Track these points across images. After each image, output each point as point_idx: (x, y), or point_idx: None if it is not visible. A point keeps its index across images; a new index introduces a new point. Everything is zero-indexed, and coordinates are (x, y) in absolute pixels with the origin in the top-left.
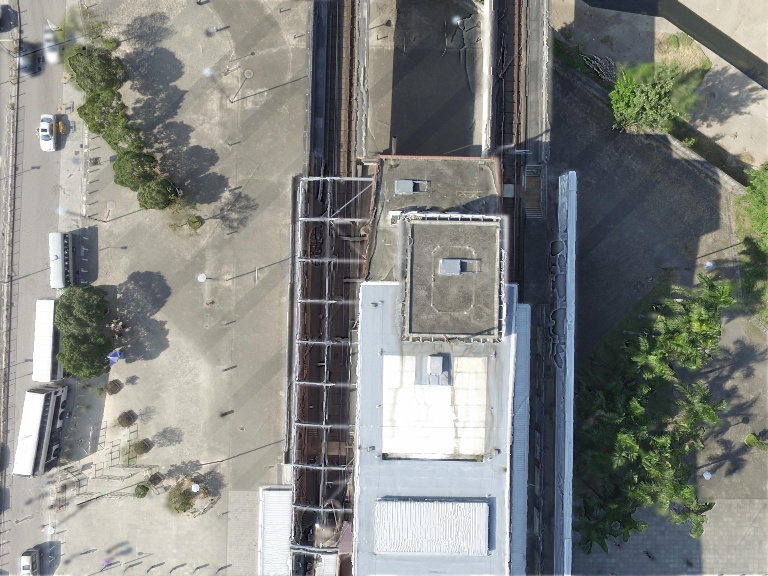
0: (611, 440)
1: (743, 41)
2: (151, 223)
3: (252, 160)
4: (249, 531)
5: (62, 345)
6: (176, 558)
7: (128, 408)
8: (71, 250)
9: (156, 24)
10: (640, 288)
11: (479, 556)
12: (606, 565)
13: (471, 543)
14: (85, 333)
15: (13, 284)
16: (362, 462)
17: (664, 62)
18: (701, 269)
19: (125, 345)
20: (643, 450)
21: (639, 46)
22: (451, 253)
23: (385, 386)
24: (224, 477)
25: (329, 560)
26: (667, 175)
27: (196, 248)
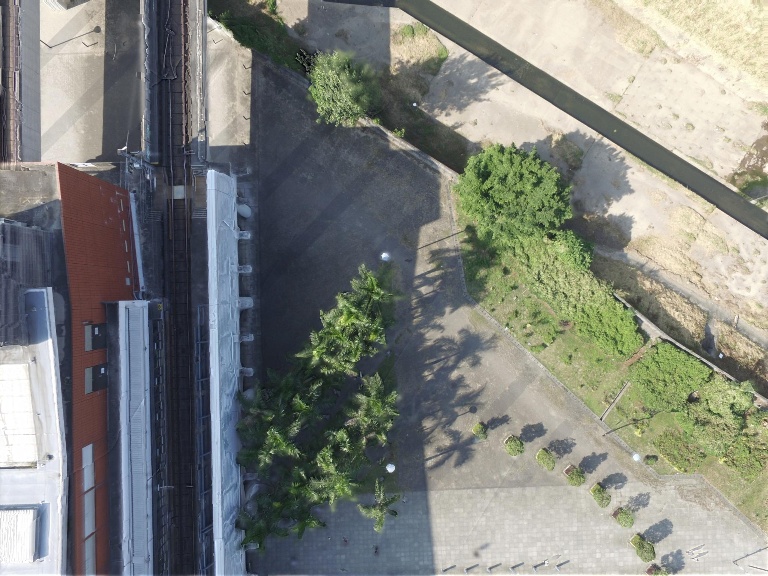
0: (264, 438)
1: (480, 27)
2: None
3: None
4: None
5: None
6: None
7: None
8: None
9: None
10: None
11: None
12: (336, 561)
13: (12, 550)
14: None
15: None
16: None
17: (400, 53)
18: (422, 260)
19: None
20: (321, 446)
21: (374, 38)
22: None
23: None
24: None
25: None
26: (384, 167)
27: None
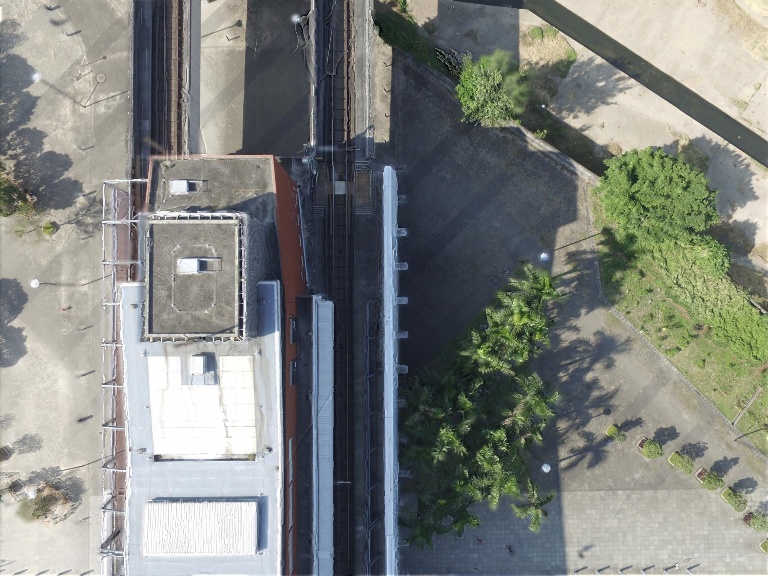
0: (434, 435)
1: (609, 31)
2: (6, 230)
3: (106, 164)
4: None
5: None
6: (39, 564)
7: None
8: None
9: (8, 31)
10: (497, 282)
11: (249, 555)
12: (469, 560)
13: (237, 543)
14: None
15: None
16: (133, 464)
17: (529, 54)
18: (559, 261)
19: None
20: (479, 444)
21: (503, 39)
22: (191, 252)
23: (152, 387)
24: (85, 482)
25: None
26: (523, 167)
27: (52, 254)
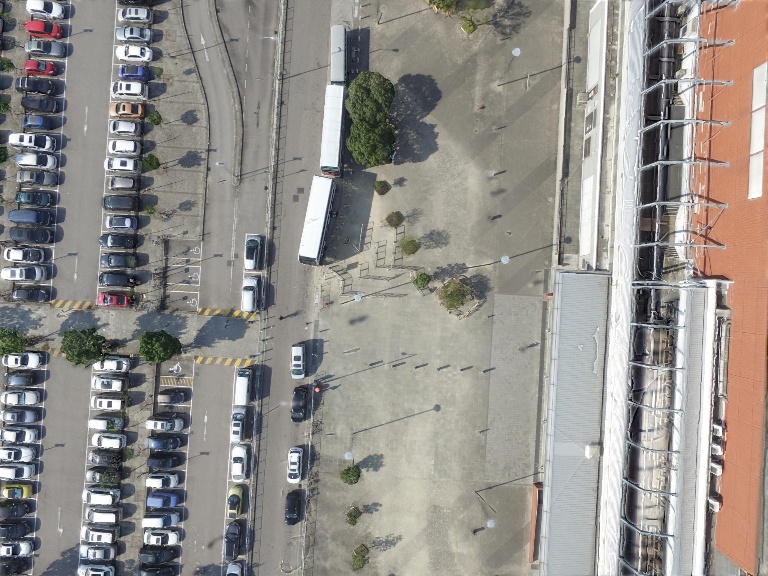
0: None
1: None
2: (423, 27)
3: None
4: (514, 335)
5: (353, 129)
6: (440, 359)
7: (395, 209)
8: (346, 48)
9: None
10: None
11: None
12: None
13: None
14: (374, 120)
15: (284, 82)
16: None
17: None
18: None
19: (394, 147)
20: None
21: None
22: None
23: None
24: (490, 281)
25: (697, 293)
26: None
27: (468, 53)
